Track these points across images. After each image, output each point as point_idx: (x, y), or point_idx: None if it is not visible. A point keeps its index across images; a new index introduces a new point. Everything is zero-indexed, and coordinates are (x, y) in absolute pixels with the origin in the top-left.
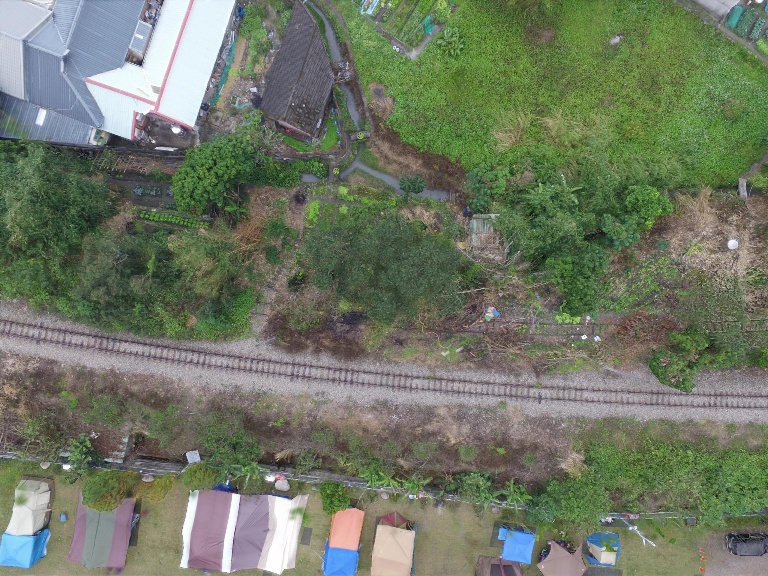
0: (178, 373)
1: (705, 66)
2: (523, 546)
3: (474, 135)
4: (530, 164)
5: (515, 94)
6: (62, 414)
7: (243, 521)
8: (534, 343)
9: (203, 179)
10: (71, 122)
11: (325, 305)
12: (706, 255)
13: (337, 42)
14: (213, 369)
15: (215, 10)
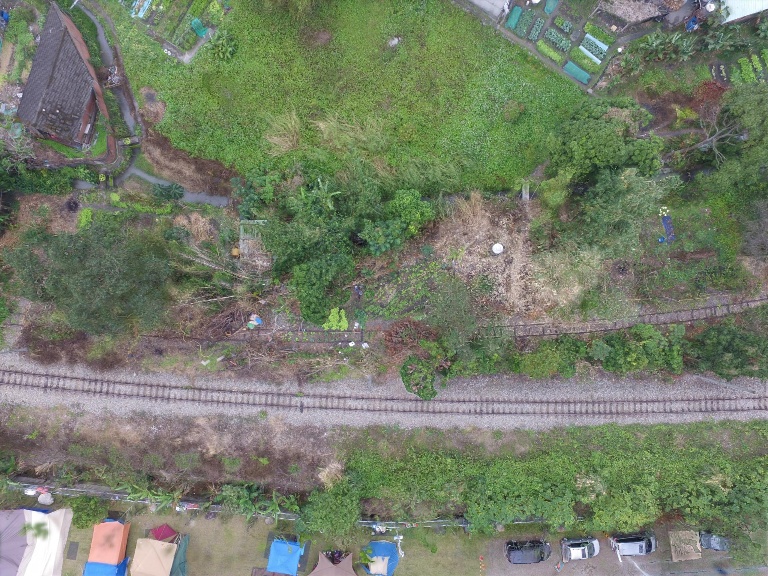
0: None
1: (485, 67)
2: (285, 558)
3: (247, 139)
4: (300, 168)
5: (289, 97)
6: None
7: None
8: (300, 351)
9: None
10: None
11: None
12: (477, 259)
13: (108, 46)
14: None
15: None
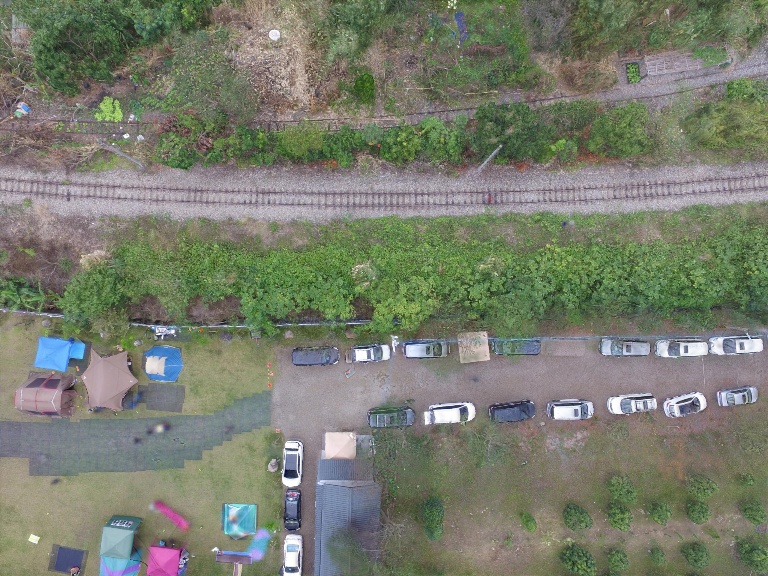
0: None
1: None
2: (51, 350)
3: None
4: None
5: None
6: None
7: None
8: (71, 141)
9: None
10: None
11: None
12: (259, 51)
13: None
14: None
15: None
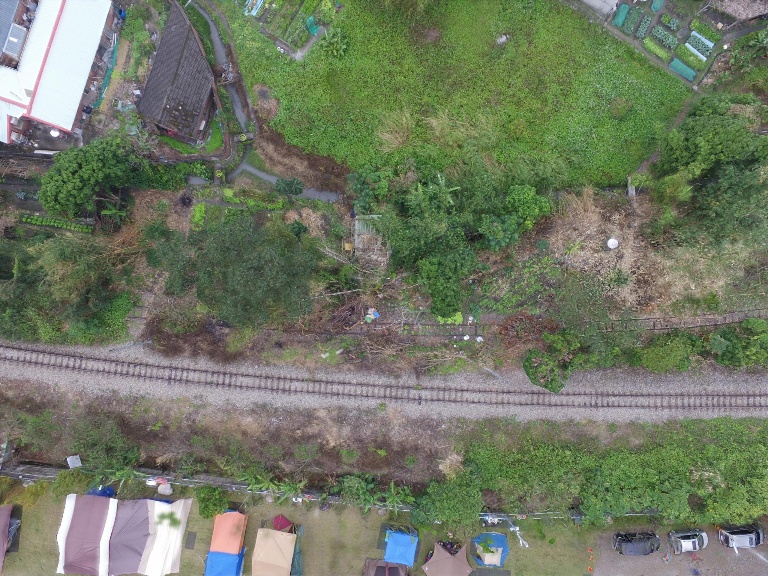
0: (54, 378)
1: (592, 65)
2: (404, 548)
3: (359, 136)
4: (413, 164)
5: (400, 94)
6: None
7: (120, 526)
8: (416, 344)
9: (67, 183)
10: None
11: None
12: (589, 254)
13: (222, 43)
14: (89, 373)
15: (89, 12)
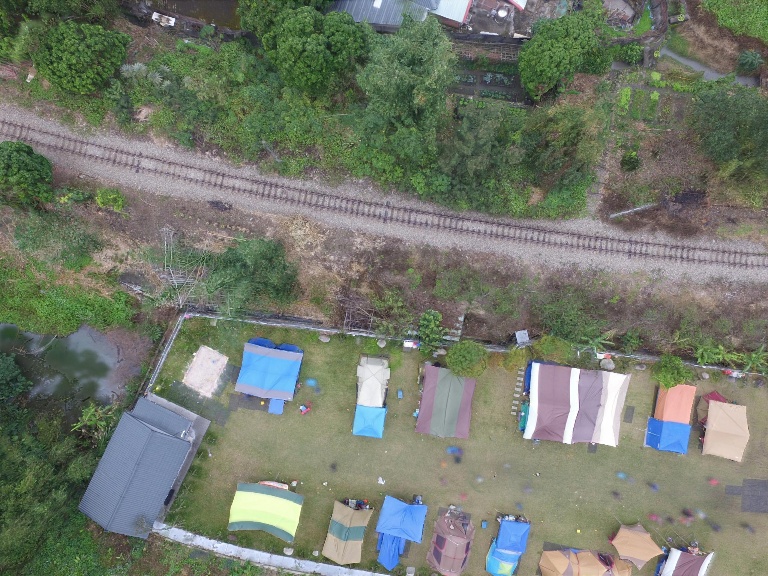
0: (518, 251)
1: None
2: None
3: None
4: None
5: None
6: (402, 293)
7: (584, 394)
8: None
9: (569, 49)
10: (407, 4)
11: (662, 183)
12: None
13: None
14: (553, 247)
15: None
